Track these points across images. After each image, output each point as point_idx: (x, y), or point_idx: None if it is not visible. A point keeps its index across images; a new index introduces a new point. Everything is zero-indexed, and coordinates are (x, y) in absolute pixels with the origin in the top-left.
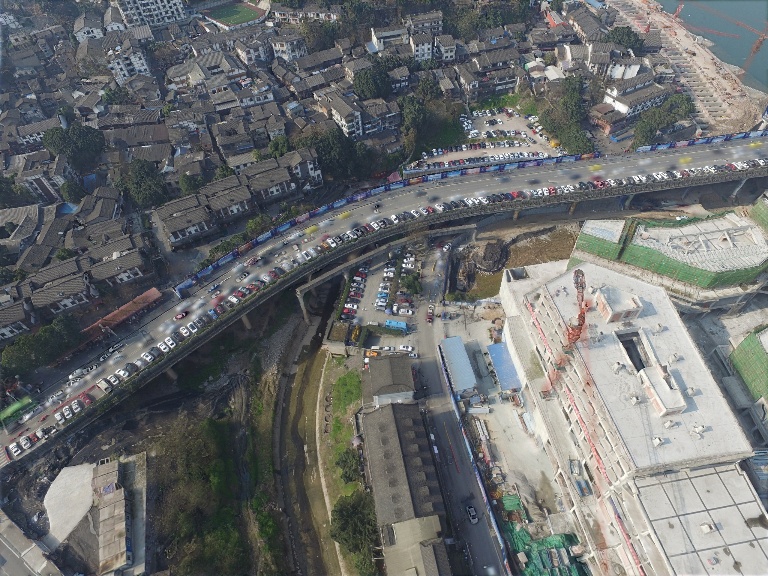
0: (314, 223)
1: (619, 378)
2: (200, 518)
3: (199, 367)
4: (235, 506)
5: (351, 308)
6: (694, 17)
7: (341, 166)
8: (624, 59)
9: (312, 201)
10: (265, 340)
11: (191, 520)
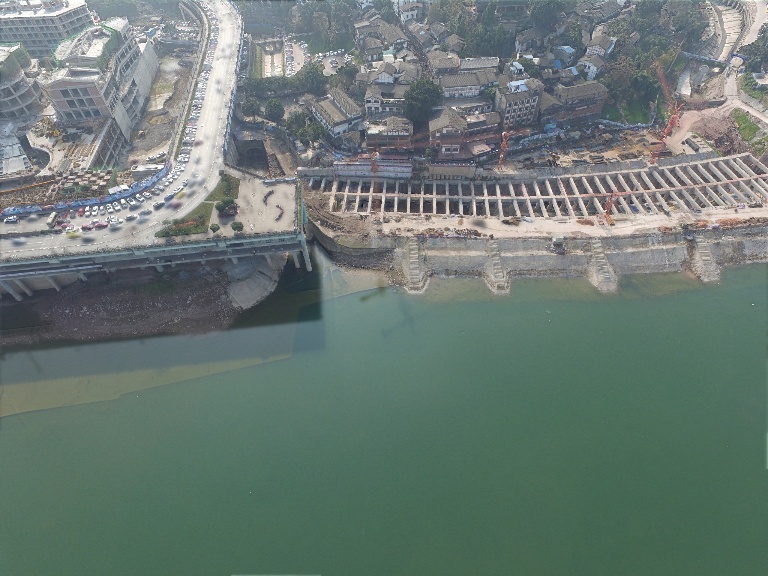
0: (222, 0)
1: (25, 4)
2: (96, 7)
3: (171, 7)
4: (102, 18)
5: (170, 23)
6: None
7: (276, 5)
8: (372, 88)
9: (256, 7)
10: (177, 18)
11: (94, 3)
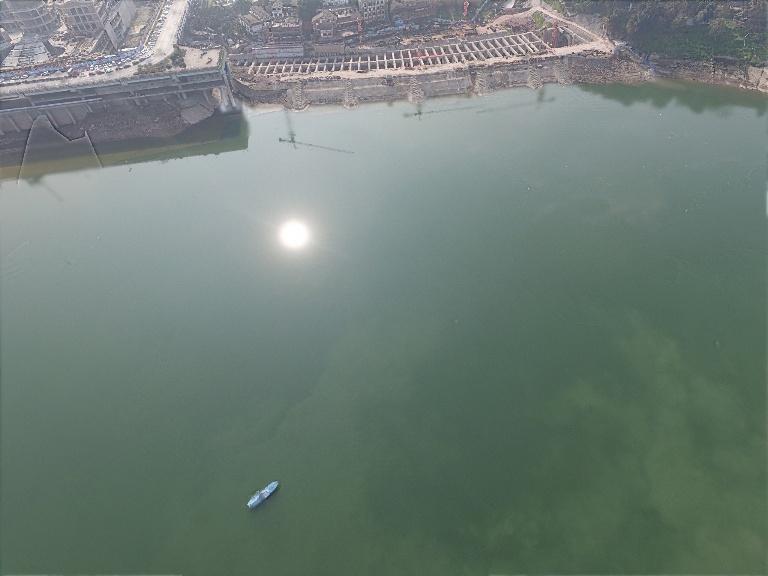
0: None
1: None
2: None
3: None
4: None
5: None
6: (494, 103)
7: None
8: (277, 2)
9: None
10: None
11: None
